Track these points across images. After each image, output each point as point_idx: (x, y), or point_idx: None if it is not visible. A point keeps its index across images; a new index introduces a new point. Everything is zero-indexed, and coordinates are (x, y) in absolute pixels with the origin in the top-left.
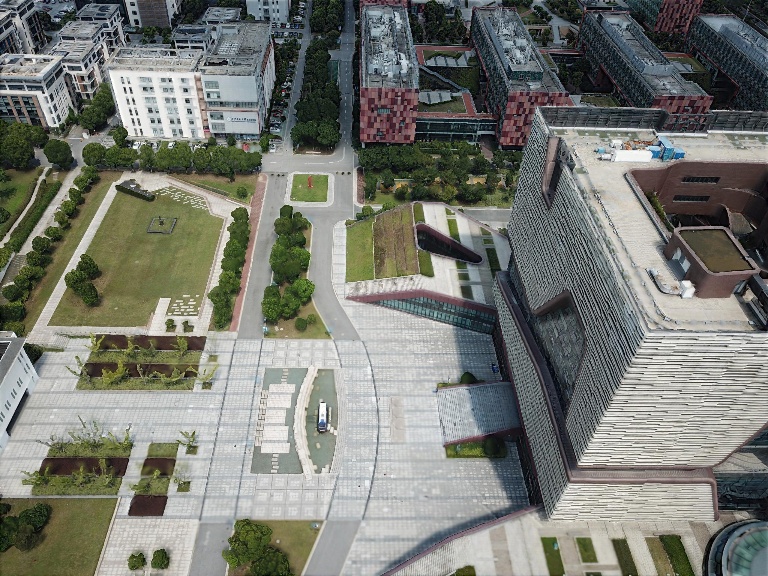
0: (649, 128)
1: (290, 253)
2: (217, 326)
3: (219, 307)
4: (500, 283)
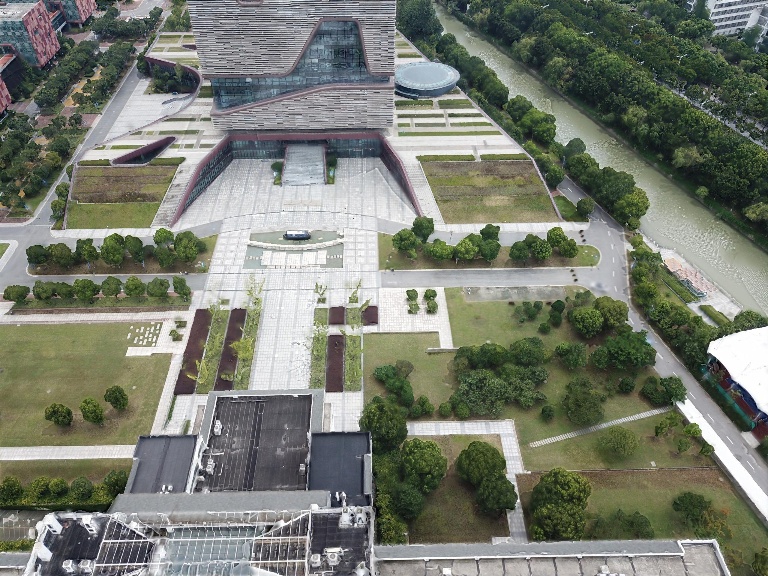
0: None
1: None
2: (185, 303)
3: (180, 280)
4: (224, 112)
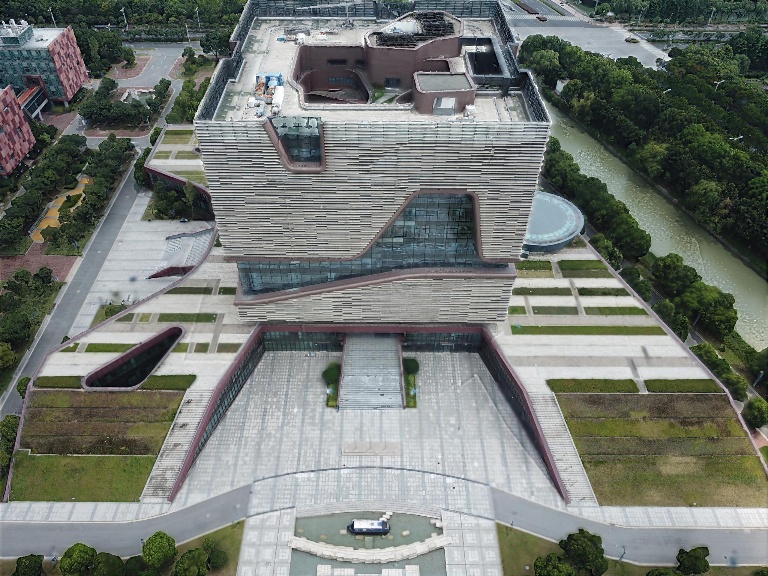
0: (227, 81)
1: (74, 572)
2: None
3: None
4: (255, 301)
